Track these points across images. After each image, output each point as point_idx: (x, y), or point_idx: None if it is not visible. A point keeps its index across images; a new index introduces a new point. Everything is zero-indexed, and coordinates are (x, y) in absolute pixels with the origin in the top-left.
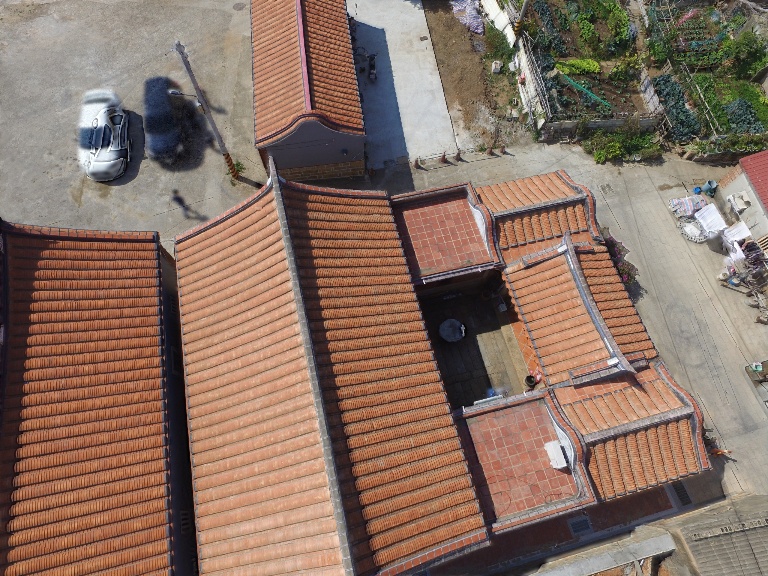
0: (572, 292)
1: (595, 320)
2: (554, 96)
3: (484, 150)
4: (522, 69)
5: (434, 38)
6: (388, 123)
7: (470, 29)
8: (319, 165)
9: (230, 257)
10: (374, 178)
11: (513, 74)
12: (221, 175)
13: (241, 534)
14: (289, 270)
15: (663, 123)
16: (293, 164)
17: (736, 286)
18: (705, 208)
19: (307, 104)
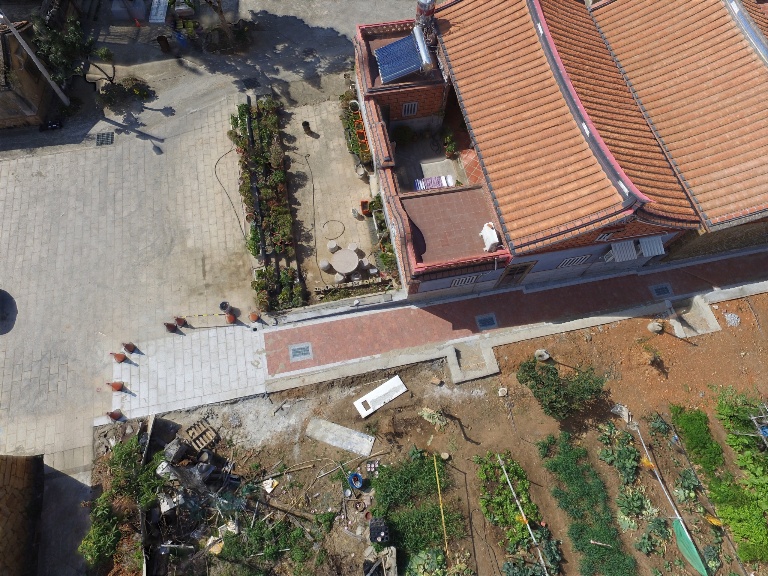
0: None
1: None
2: None
3: None
4: None
5: None
6: None
7: None
8: None
9: (652, 12)
10: None
11: None
12: None
13: (727, 176)
14: (725, 8)
15: None
16: None
17: None
18: None
19: None
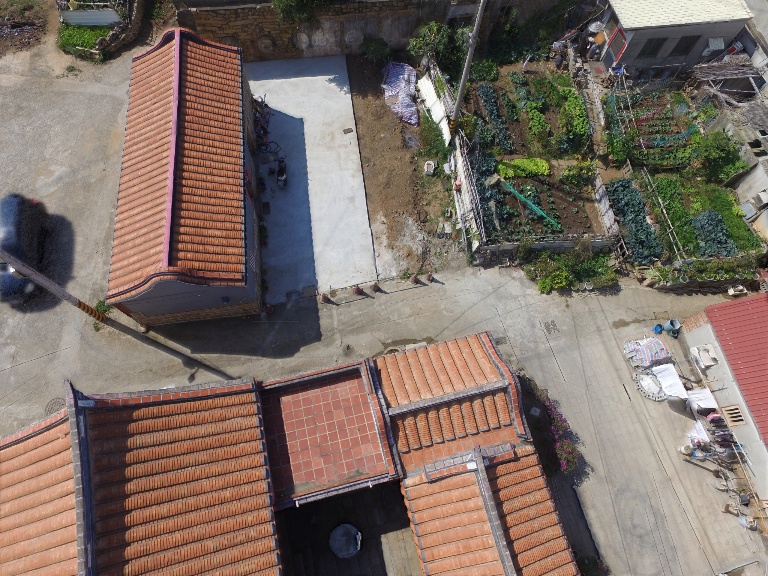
0: (483, 526)
1: (508, 575)
2: (492, 210)
3: (408, 277)
4: (458, 172)
5: (360, 130)
6: (296, 241)
7: (402, 119)
8: (199, 309)
9: (26, 496)
10: (272, 316)
11: (448, 177)
12: (83, 317)
13: None
14: None
15: (619, 245)
16: (165, 311)
17: (701, 461)
18: (663, 367)
19: (164, 258)
